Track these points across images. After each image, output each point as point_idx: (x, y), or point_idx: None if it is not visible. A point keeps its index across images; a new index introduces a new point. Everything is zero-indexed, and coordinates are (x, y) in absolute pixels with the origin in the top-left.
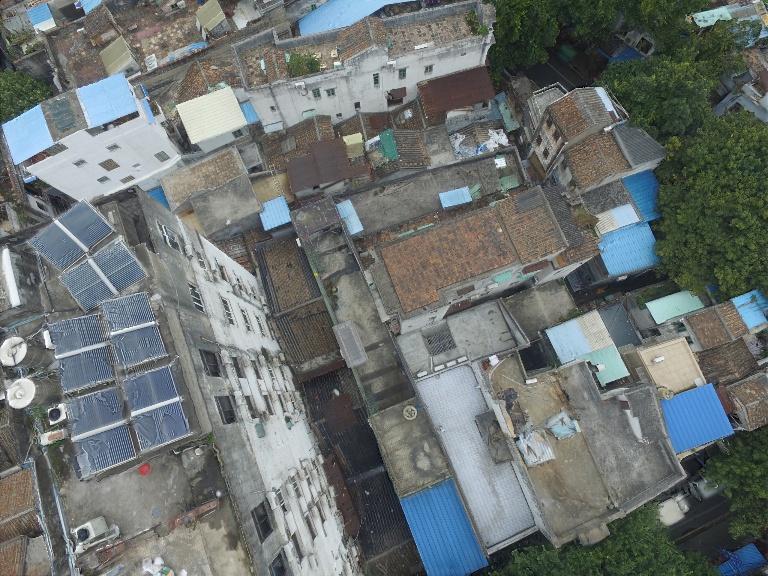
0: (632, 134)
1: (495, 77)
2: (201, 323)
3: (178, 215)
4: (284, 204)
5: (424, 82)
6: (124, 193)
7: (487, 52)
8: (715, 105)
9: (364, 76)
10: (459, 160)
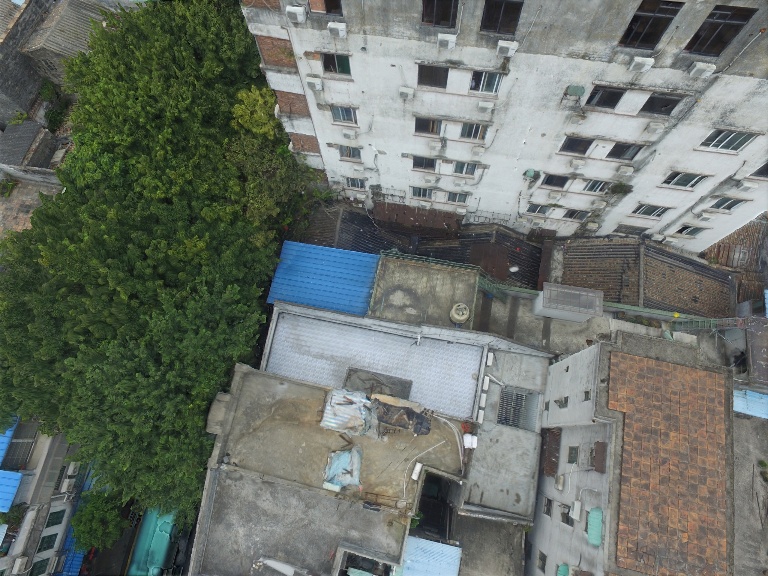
0: None
1: None
2: None
3: None
4: None
5: None
6: None
7: None
8: None
9: None
10: None
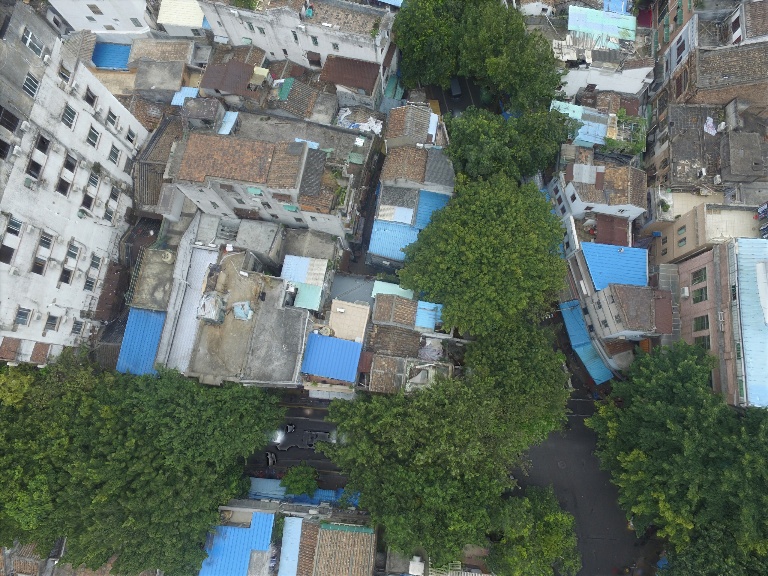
0: (440, 159)
1: (408, 84)
2: (19, 97)
3: (131, 69)
4: (195, 94)
5: (333, 56)
6: (12, 0)
7: (403, 60)
8: (548, 182)
9: (284, 29)
10: (330, 124)
